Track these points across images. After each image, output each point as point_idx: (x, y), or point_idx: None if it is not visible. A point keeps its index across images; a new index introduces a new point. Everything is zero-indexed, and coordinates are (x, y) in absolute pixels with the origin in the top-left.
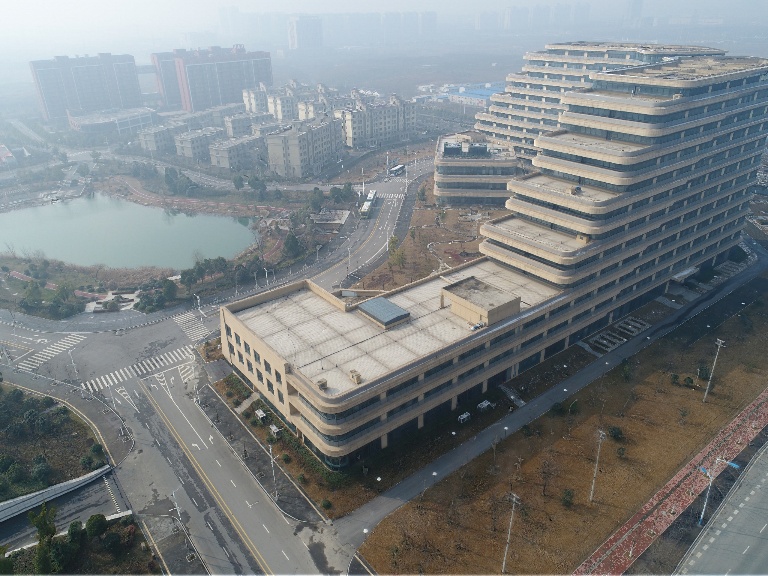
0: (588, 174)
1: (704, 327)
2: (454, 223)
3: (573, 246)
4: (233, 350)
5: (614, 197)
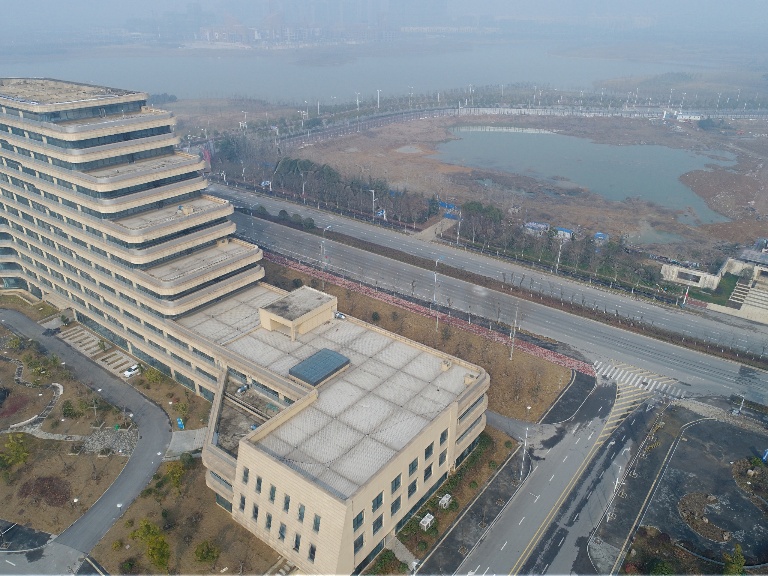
0: (179, 191)
1: None
2: None
3: (233, 248)
4: (358, 544)
5: None
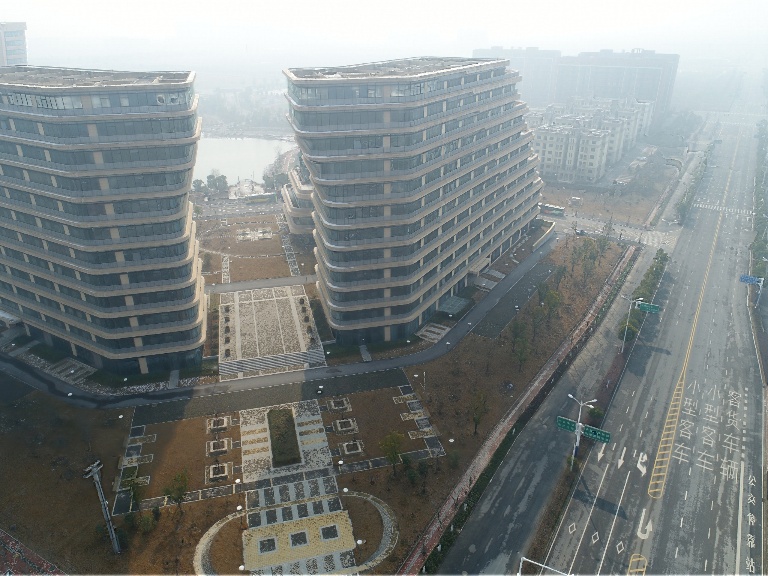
0: None
1: None
2: (228, 228)
3: None
4: None
5: None
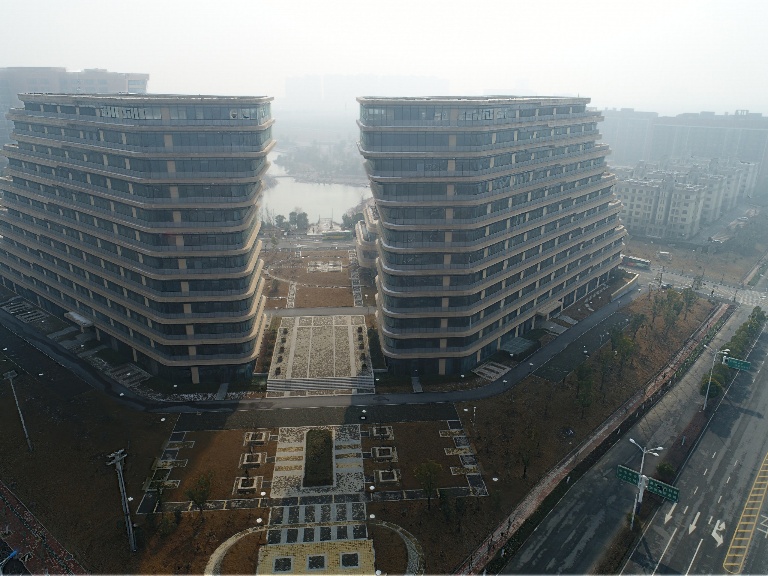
0: None
1: (0, 342)
2: None
3: None
4: None
5: (4, 179)
